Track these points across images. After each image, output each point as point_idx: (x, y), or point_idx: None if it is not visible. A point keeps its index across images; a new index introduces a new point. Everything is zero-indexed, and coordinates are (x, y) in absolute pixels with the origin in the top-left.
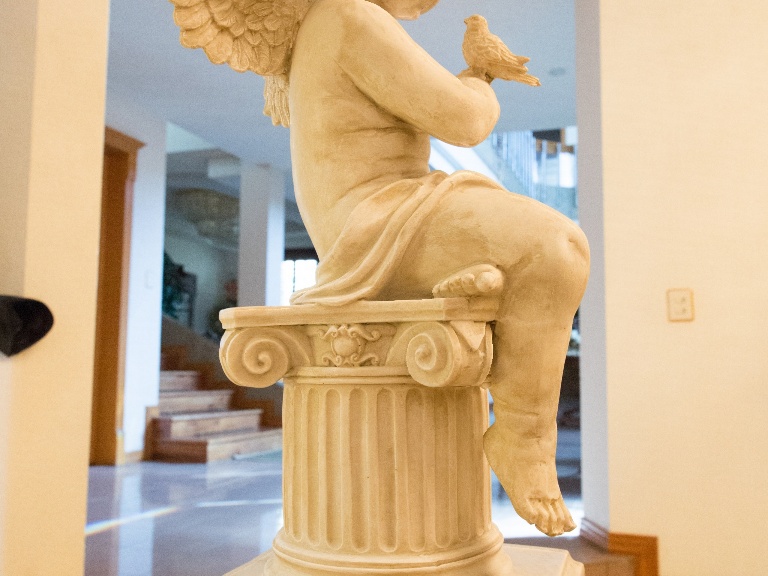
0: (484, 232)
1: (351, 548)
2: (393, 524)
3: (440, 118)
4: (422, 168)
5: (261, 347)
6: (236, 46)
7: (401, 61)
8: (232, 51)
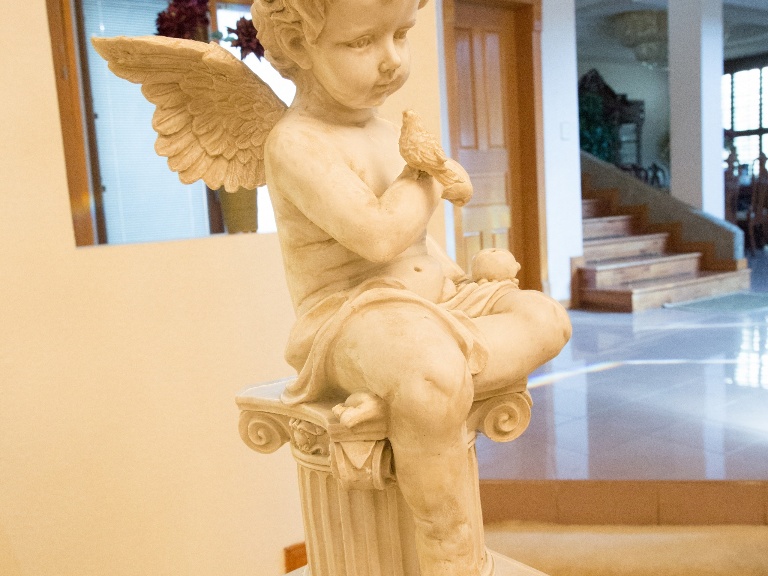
0: (361, 365)
1: None
2: None
3: (347, 243)
4: (380, 263)
5: (258, 425)
6: (231, 167)
7: (311, 192)
8: (226, 174)
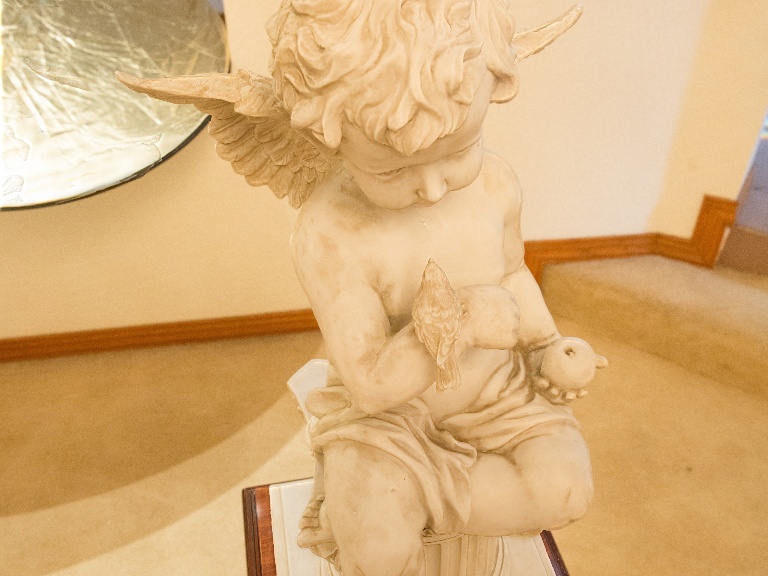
0: None
1: None
2: None
3: None
4: None
5: None
6: (298, 178)
7: (316, 312)
8: (291, 186)
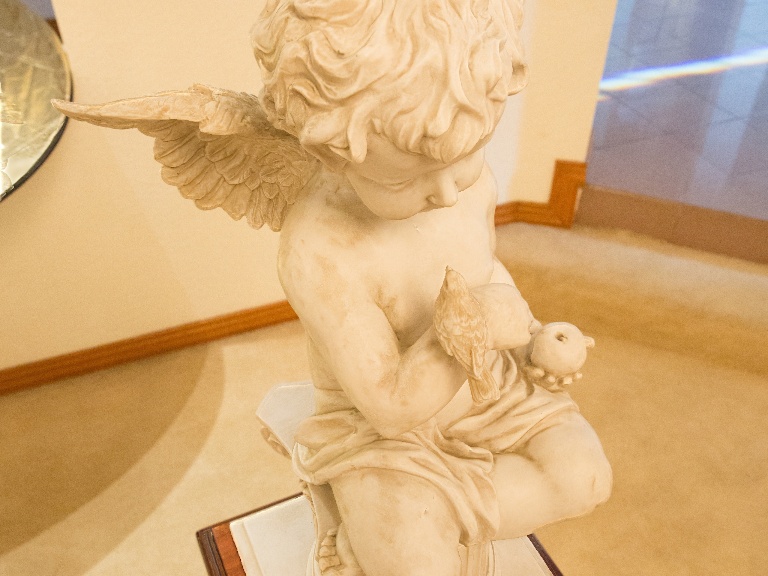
0: (349, 537)
1: None
2: None
3: None
4: None
5: None
6: (256, 196)
7: (320, 339)
8: (249, 205)
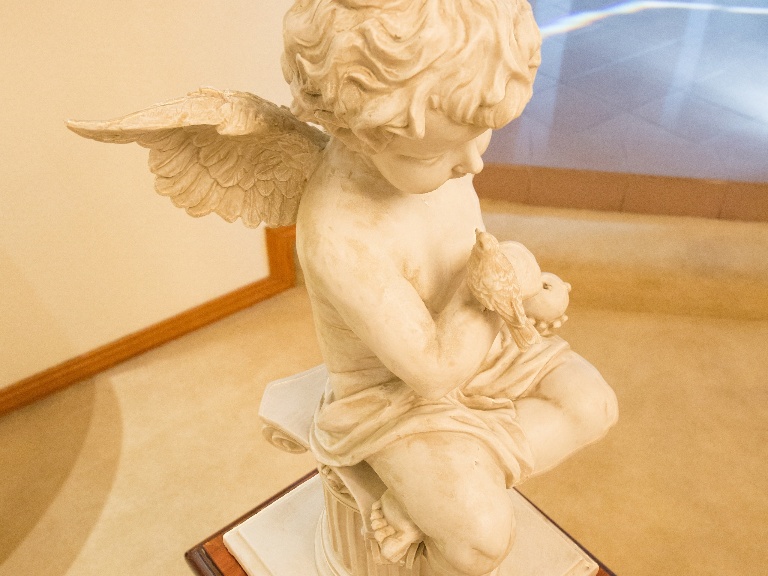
0: (405, 503)
1: (343, 566)
2: (367, 572)
3: None
4: None
5: None
6: (249, 195)
7: (359, 320)
8: (243, 205)
